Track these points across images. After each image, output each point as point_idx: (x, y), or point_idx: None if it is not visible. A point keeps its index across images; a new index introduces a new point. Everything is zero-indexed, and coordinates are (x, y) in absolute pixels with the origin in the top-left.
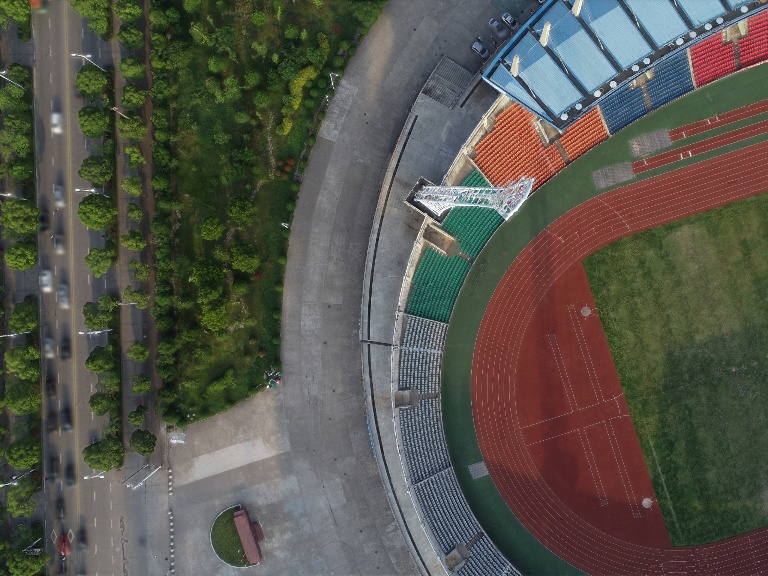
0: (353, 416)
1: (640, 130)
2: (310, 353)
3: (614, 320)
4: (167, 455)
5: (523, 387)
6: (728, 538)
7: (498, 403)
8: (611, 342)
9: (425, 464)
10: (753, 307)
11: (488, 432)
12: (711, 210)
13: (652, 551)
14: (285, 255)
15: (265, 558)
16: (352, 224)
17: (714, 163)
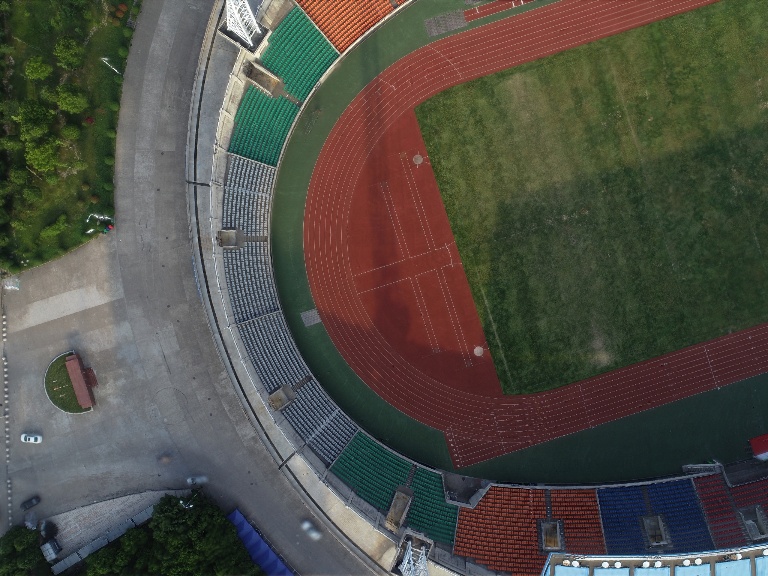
0: (186, 263)
1: None
2: (143, 200)
3: (446, 168)
4: (1, 301)
5: (355, 235)
6: (559, 387)
7: (330, 251)
8: (443, 190)
9: (251, 305)
10: (584, 155)
11: (320, 280)
12: (543, 58)
13: (484, 399)
14: (118, 101)
15: (99, 404)
16: (185, 71)
17: (546, 11)
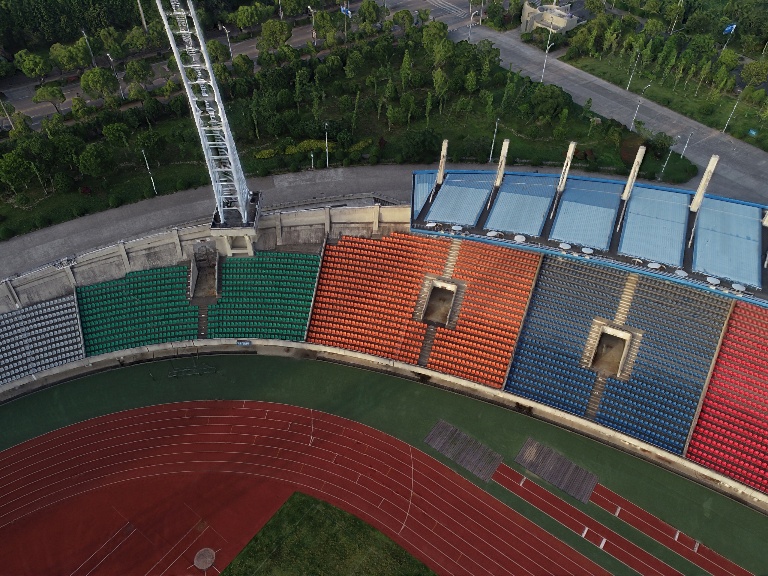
0: None
1: (558, 442)
2: None
3: None
4: None
5: (2, 542)
6: None
7: None
8: None
9: None
10: None
11: None
12: None
13: None
14: (122, 202)
15: None
16: None
17: None
